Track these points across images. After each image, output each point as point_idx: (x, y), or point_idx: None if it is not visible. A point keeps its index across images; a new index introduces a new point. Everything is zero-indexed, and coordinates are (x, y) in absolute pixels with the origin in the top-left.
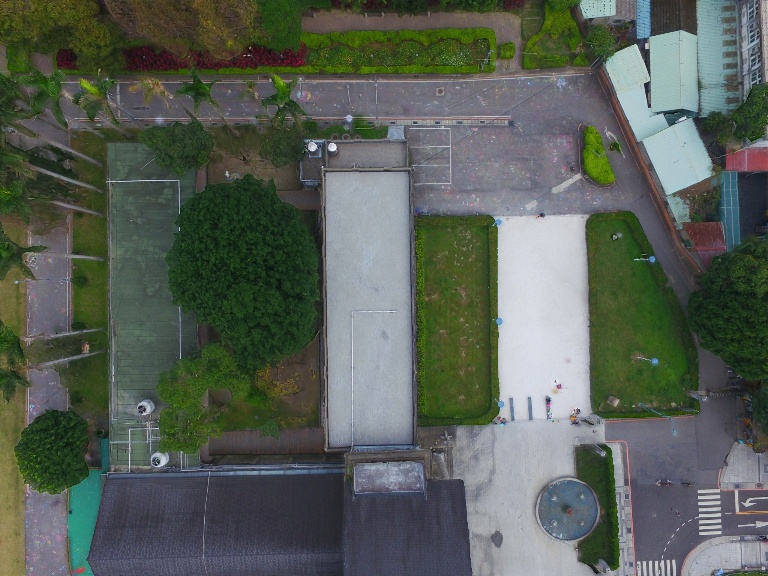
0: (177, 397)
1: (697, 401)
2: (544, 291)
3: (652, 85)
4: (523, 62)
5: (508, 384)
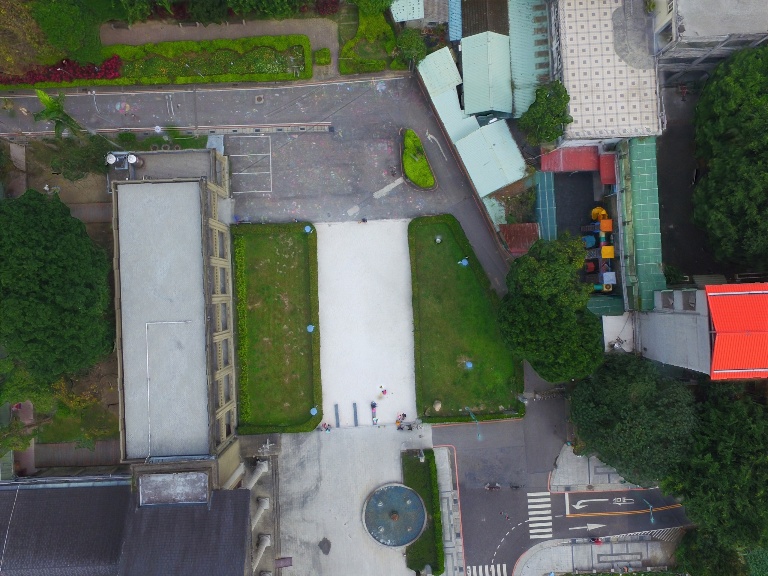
0: None
1: (522, 404)
2: (368, 296)
3: (465, 87)
4: (339, 67)
5: (333, 391)
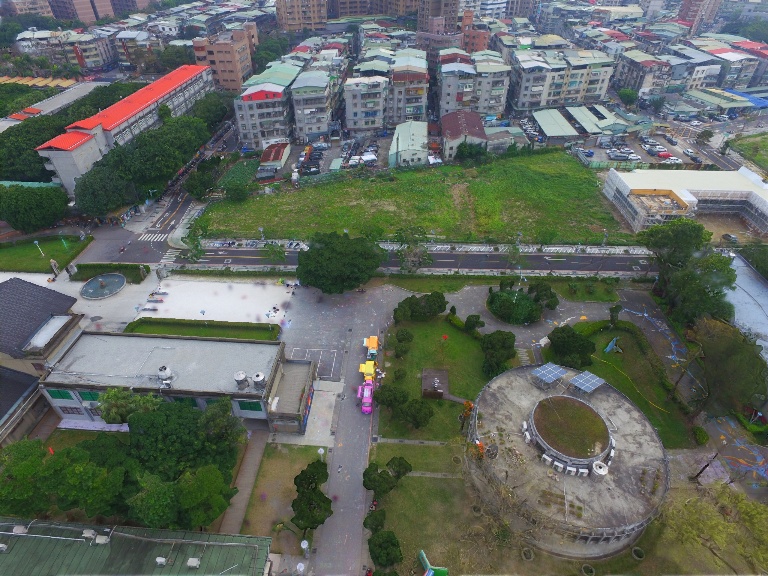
0: None
1: None
2: None
3: None
4: None
5: None
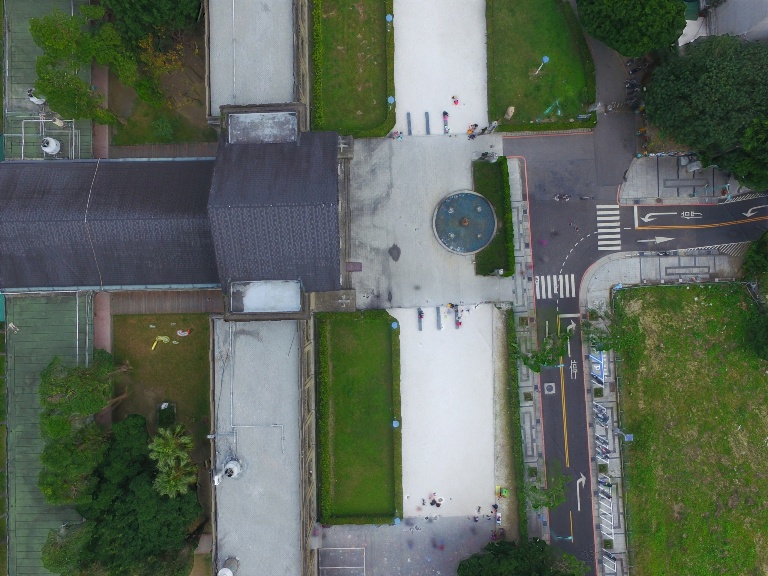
0: (47, 30)
1: (594, 112)
2: (442, 9)
3: None
4: None
5: (406, 100)
